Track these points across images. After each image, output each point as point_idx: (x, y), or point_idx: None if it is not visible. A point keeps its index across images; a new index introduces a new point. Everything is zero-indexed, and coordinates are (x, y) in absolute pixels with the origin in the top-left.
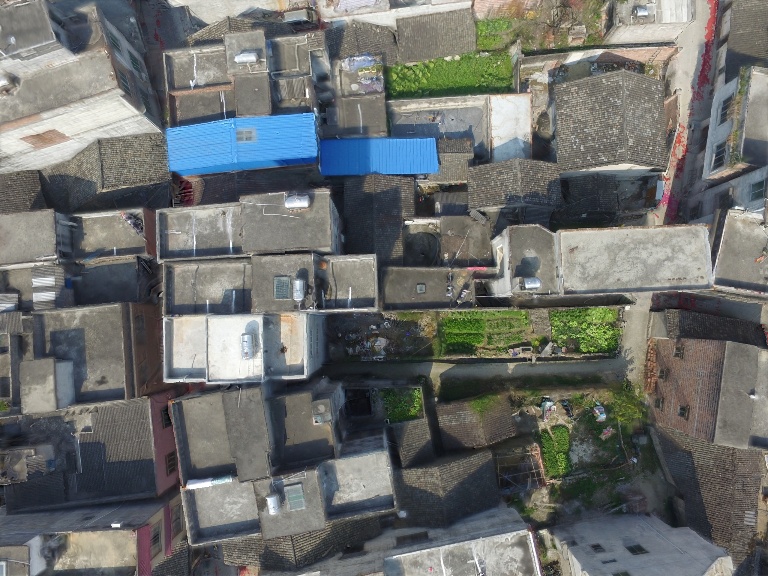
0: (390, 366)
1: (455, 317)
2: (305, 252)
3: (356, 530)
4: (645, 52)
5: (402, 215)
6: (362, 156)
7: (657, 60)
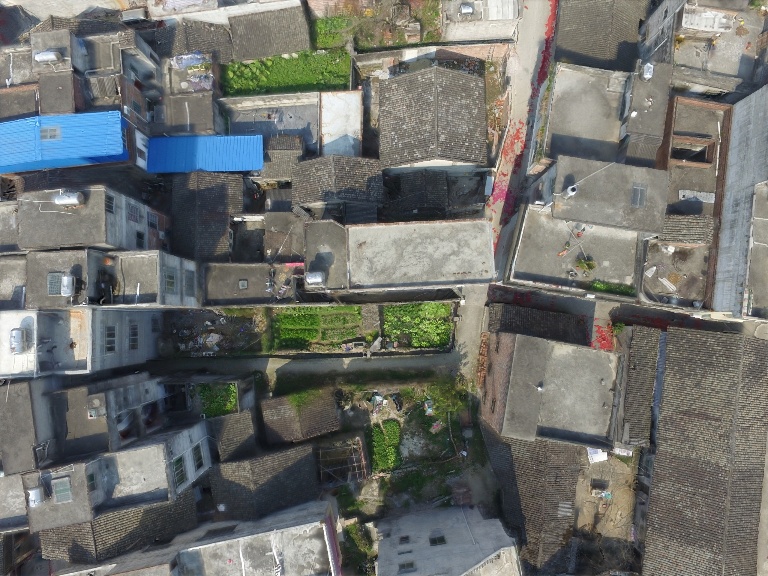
0: (226, 362)
1: (290, 313)
2: (79, 248)
3: (168, 523)
4: (480, 49)
5: (229, 212)
6: (189, 153)
7: (496, 57)
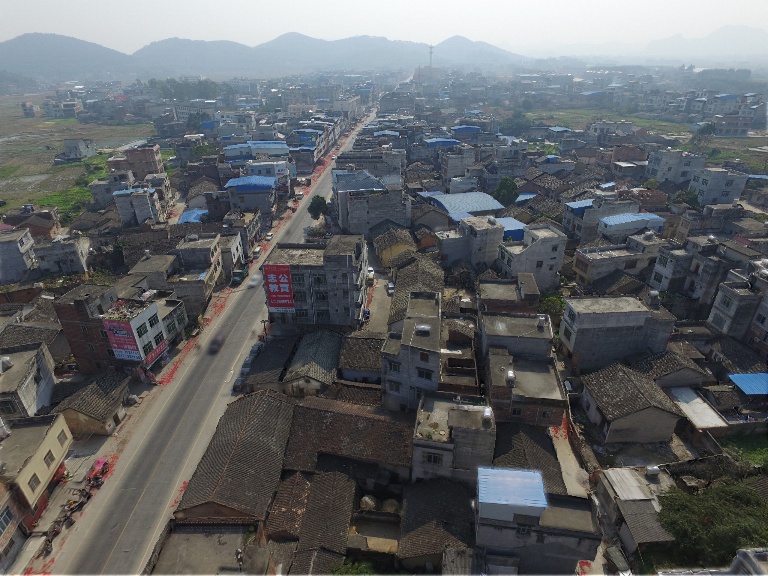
0: None
1: None
2: None
3: None
4: None
5: None
6: None
7: None
